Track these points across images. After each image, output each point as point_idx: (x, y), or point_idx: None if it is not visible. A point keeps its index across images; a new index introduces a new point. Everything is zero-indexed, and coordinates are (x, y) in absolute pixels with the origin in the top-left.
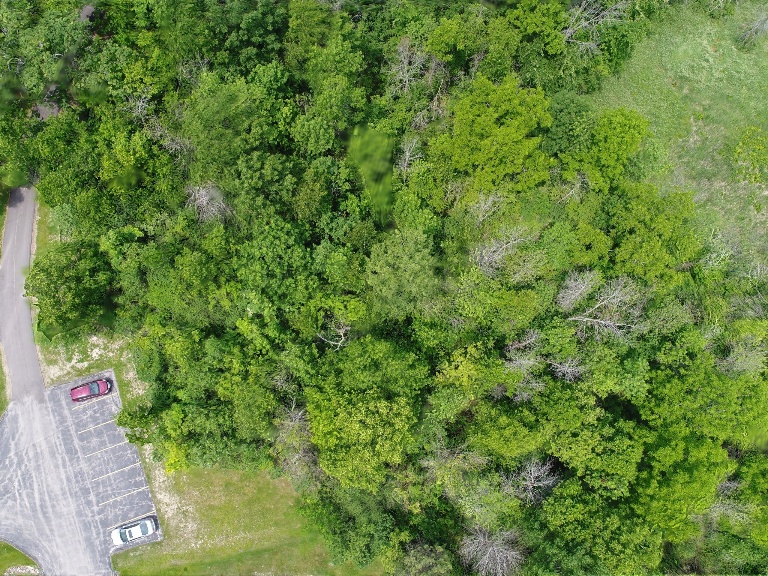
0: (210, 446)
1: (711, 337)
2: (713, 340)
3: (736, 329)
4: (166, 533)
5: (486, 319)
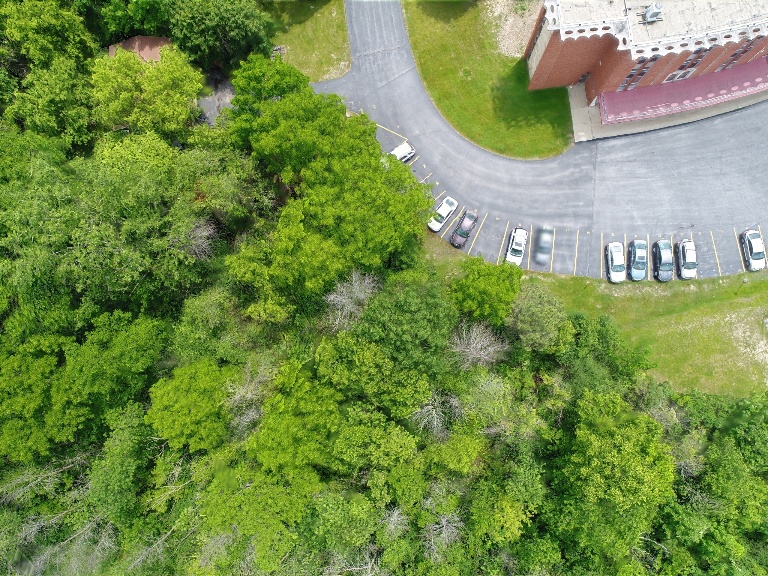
0: (763, 430)
1: (258, 569)
2: (257, 567)
3: (223, 573)
4: (762, 326)
5: (487, 573)
